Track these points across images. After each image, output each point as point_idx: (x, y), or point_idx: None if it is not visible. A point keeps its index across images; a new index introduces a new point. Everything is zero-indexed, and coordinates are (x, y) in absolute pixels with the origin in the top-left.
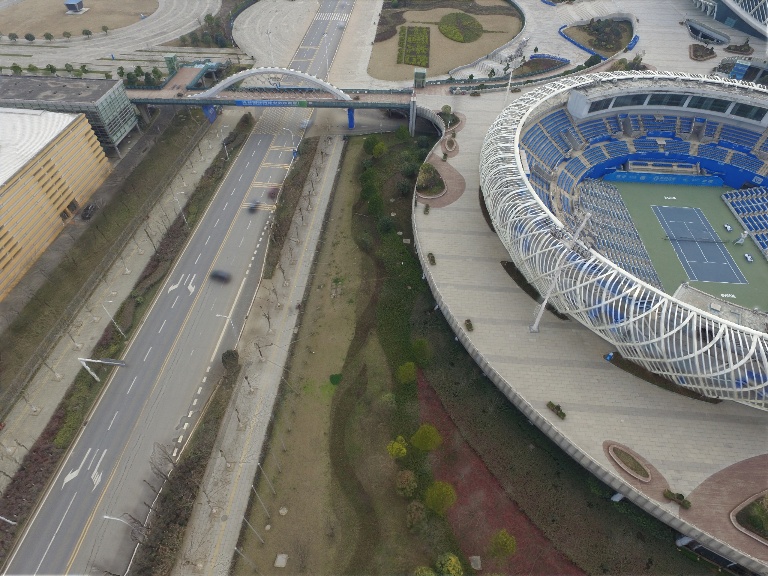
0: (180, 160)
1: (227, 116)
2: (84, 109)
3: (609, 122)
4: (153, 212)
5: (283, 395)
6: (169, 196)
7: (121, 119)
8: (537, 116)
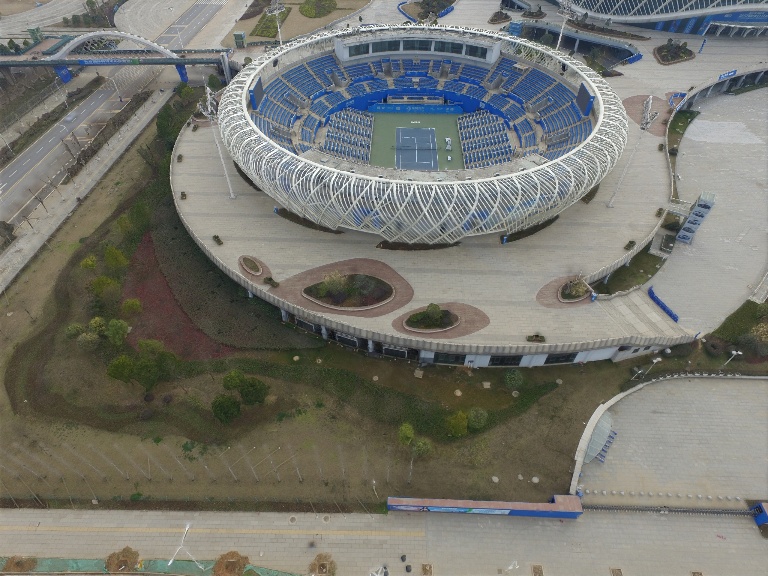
0: (24, 108)
1: (82, 77)
2: None
3: (374, 65)
4: None
5: (41, 252)
6: (7, 133)
7: None
8: (305, 59)
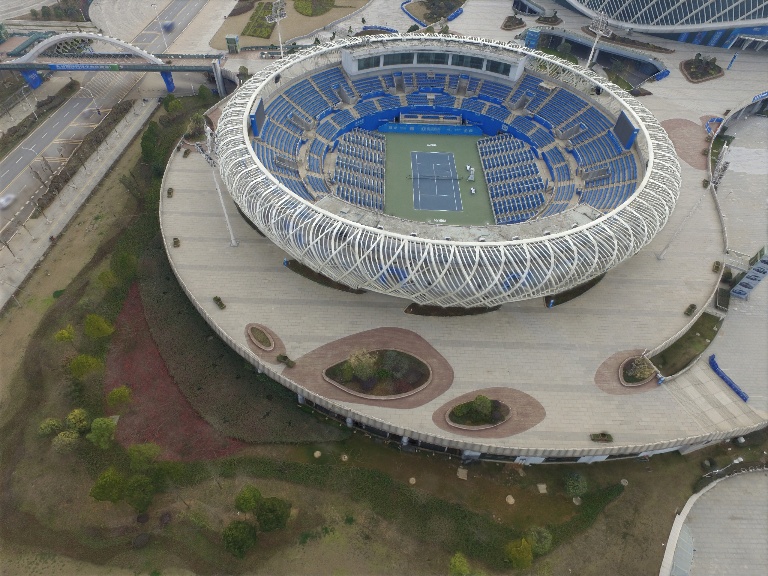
0: None
1: (54, 82)
2: None
3: (384, 79)
4: None
5: (7, 309)
6: None
7: None
8: (309, 72)
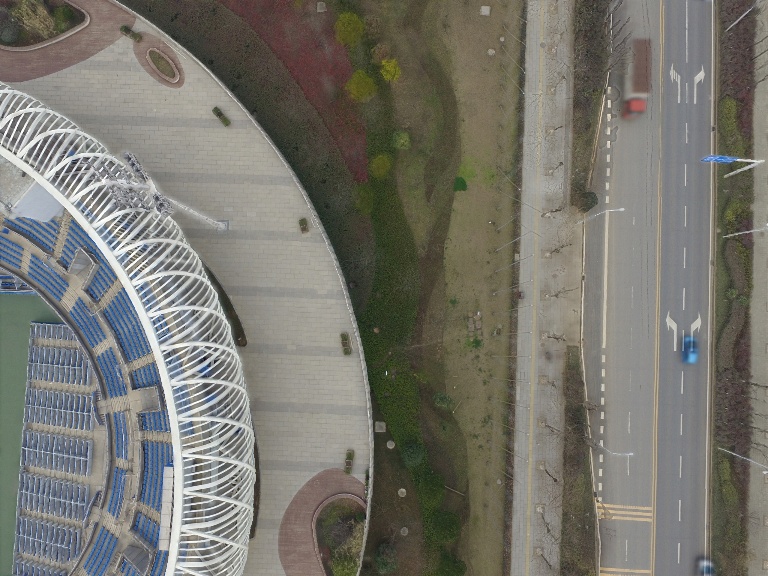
0: None
1: None
2: None
3: None
4: None
5: (515, 168)
6: None
7: None
8: None
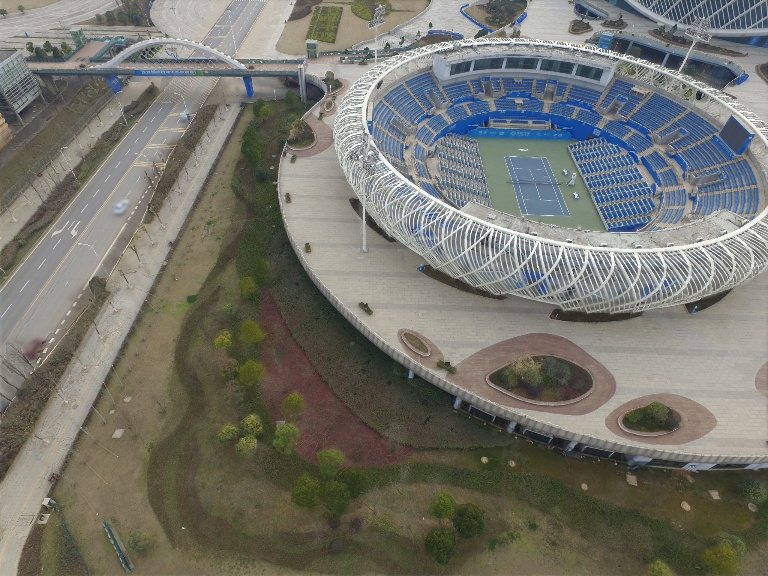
0: (79, 125)
1: (133, 87)
2: None
3: (473, 84)
4: (47, 170)
5: (144, 314)
6: (65, 157)
7: (22, 88)
8: (403, 78)
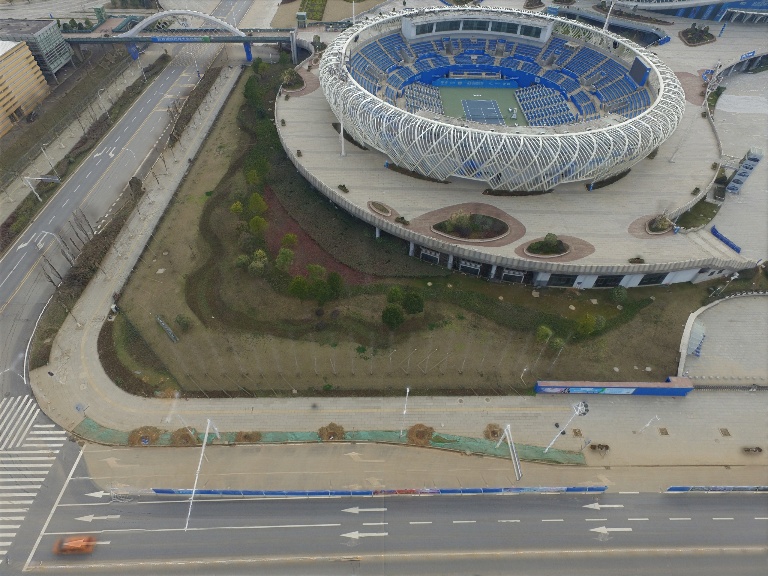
0: (106, 81)
1: (148, 55)
2: (25, 40)
3: (436, 44)
4: (84, 114)
5: (173, 204)
6: None
7: (57, 52)
8: (376, 36)
